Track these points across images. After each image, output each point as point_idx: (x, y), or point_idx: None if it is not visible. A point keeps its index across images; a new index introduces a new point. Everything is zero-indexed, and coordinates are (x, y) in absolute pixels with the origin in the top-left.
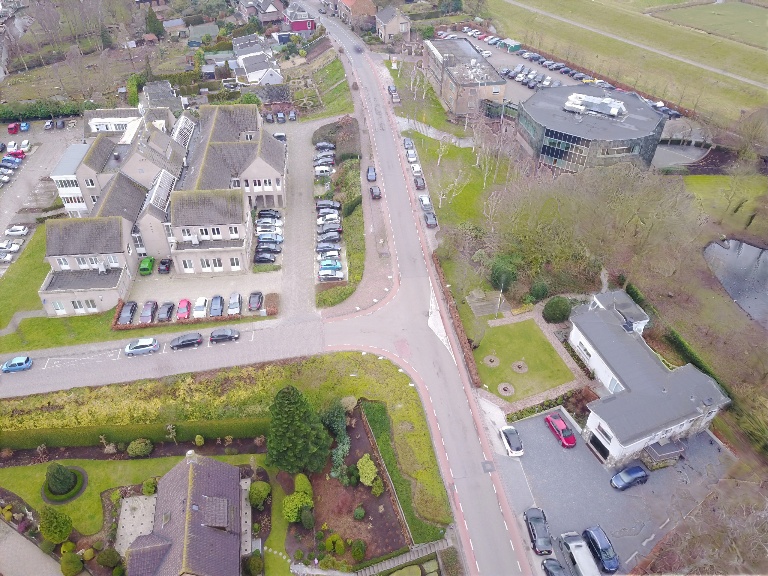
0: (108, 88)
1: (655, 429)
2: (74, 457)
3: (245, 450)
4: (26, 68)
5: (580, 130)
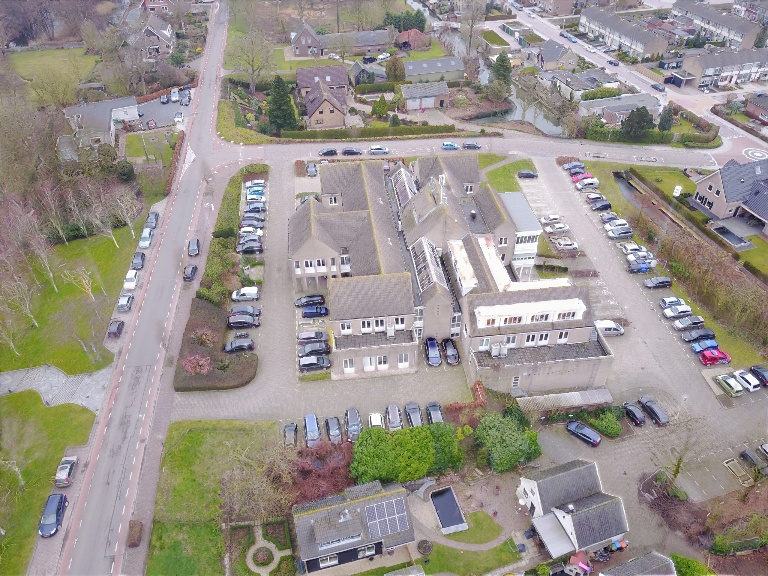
0: None
1: (114, 100)
2: None
3: None
4: None
5: None
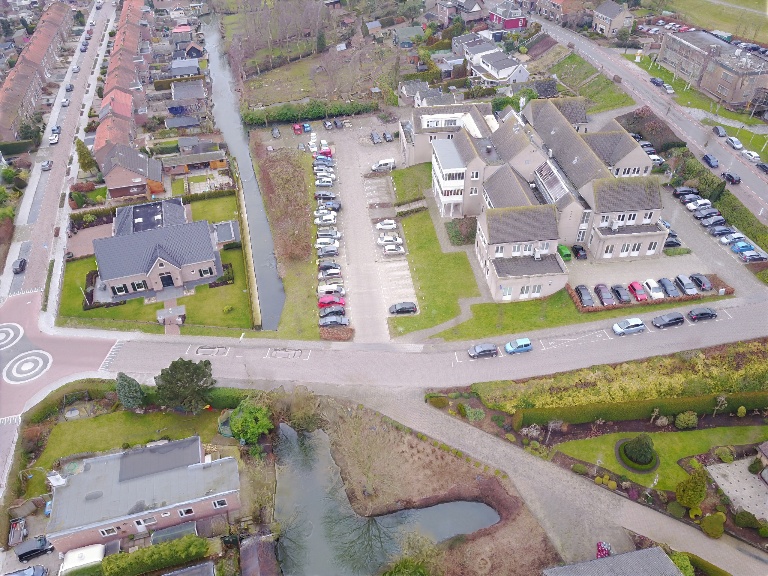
0: (353, 89)
1: None
2: (624, 430)
3: None
4: (258, 72)
5: None
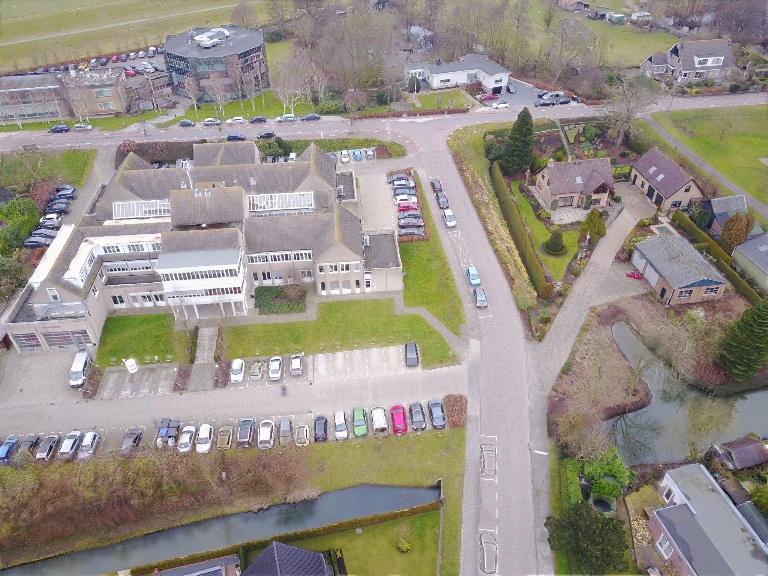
0: None
1: (499, 67)
2: None
3: (510, 191)
4: None
5: (243, 47)
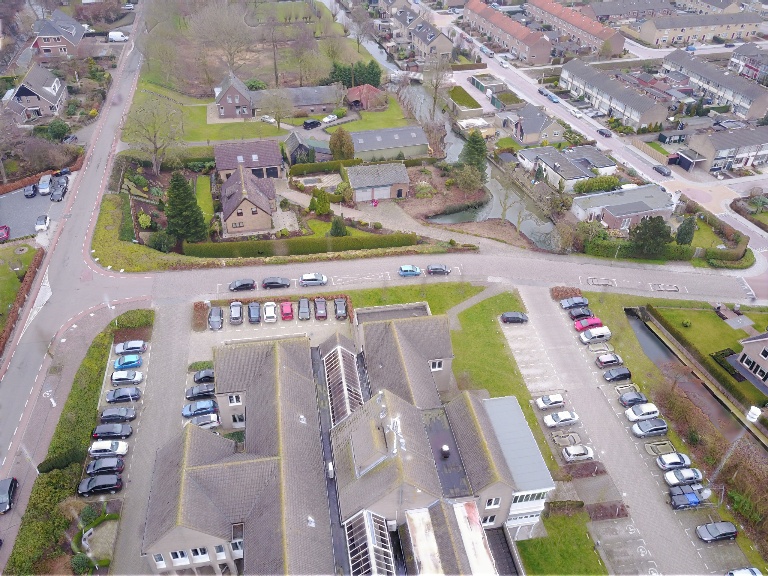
0: None
1: None
2: None
3: None
4: None
5: None
